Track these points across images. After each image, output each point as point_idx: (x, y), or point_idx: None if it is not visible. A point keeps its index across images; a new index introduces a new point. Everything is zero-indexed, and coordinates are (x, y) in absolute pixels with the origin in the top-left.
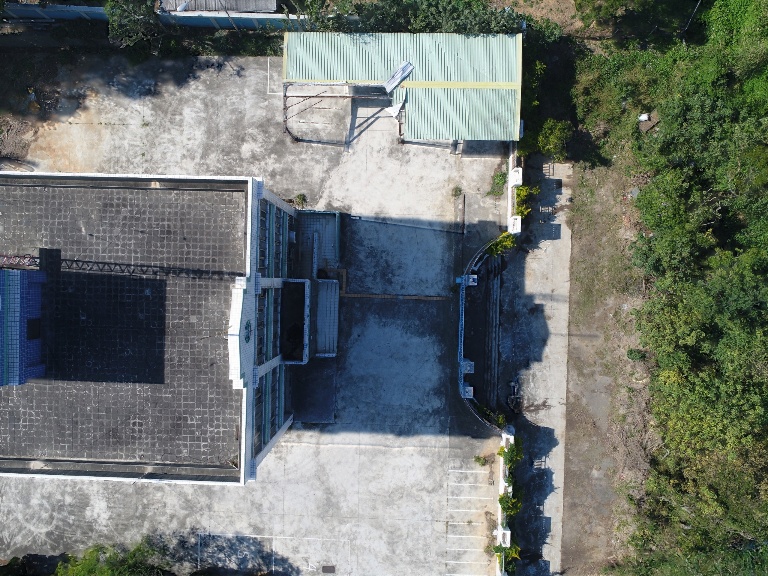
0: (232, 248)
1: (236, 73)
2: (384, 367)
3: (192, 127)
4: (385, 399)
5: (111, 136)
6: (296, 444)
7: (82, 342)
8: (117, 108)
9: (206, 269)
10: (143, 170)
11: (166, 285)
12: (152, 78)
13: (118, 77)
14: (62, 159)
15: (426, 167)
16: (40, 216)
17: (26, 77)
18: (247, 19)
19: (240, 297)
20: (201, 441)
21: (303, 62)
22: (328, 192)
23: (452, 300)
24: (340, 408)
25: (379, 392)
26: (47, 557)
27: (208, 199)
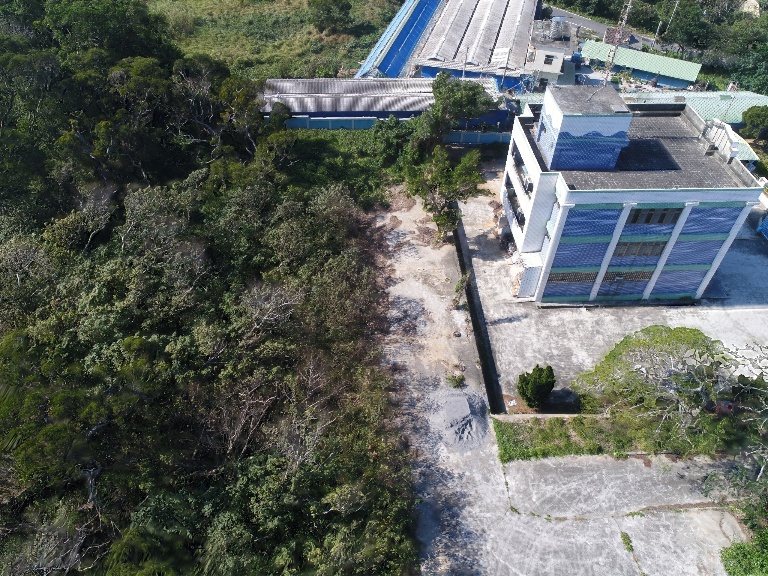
0: None
1: None
2: (742, 269)
3: None
4: (754, 285)
5: None
6: (709, 311)
7: None
8: None
9: (677, 136)
10: None
11: (660, 141)
12: None
13: None
14: None
15: None
16: None
17: None
18: None
19: None
20: None
21: None
22: None
23: (760, 239)
24: (727, 290)
25: (747, 281)
26: (551, 391)
27: None
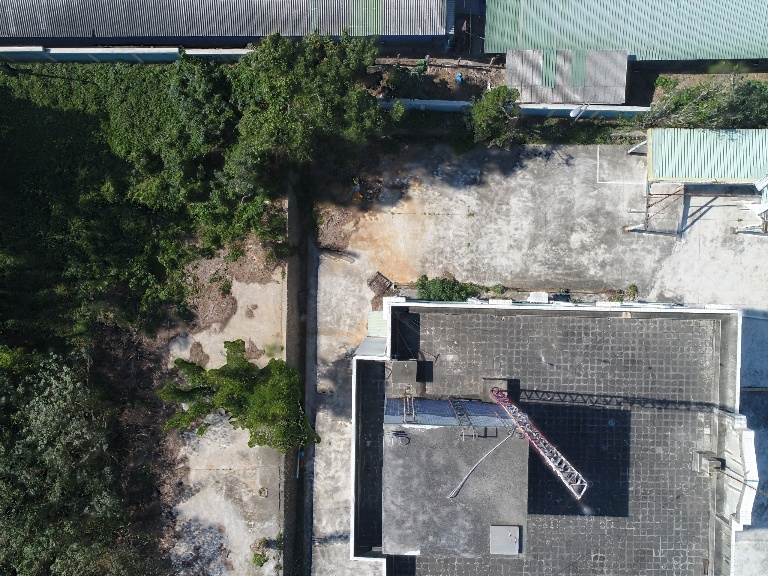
0: (699, 377)
1: (565, 162)
2: None
3: (519, 217)
4: None
5: (435, 226)
6: None
7: (542, 474)
8: (441, 198)
9: (672, 399)
10: (468, 261)
11: (630, 416)
12: (477, 167)
13: (442, 166)
14: (384, 250)
15: (761, 256)
16: (498, 345)
17: (349, 167)
18: (591, 111)
19: (751, 440)
20: (666, 575)
21: (669, 159)
22: (660, 282)
23: None
24: None
25: None
26: None
27: (674, 327)
